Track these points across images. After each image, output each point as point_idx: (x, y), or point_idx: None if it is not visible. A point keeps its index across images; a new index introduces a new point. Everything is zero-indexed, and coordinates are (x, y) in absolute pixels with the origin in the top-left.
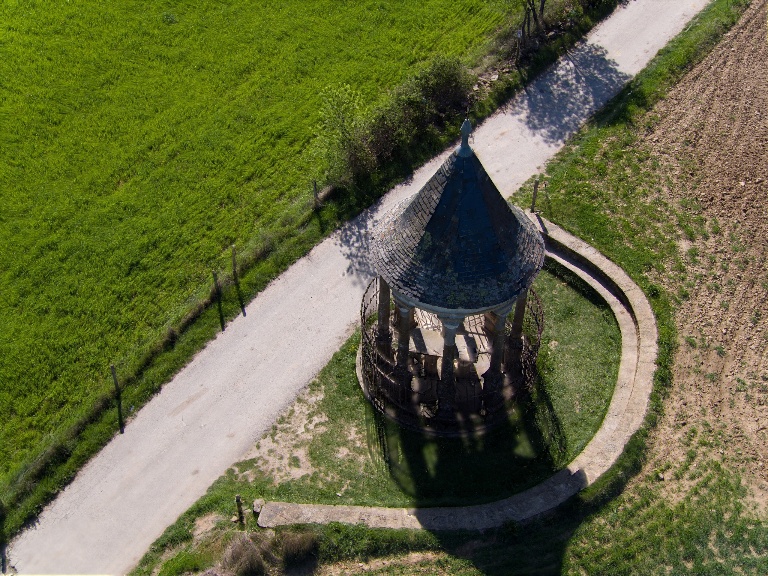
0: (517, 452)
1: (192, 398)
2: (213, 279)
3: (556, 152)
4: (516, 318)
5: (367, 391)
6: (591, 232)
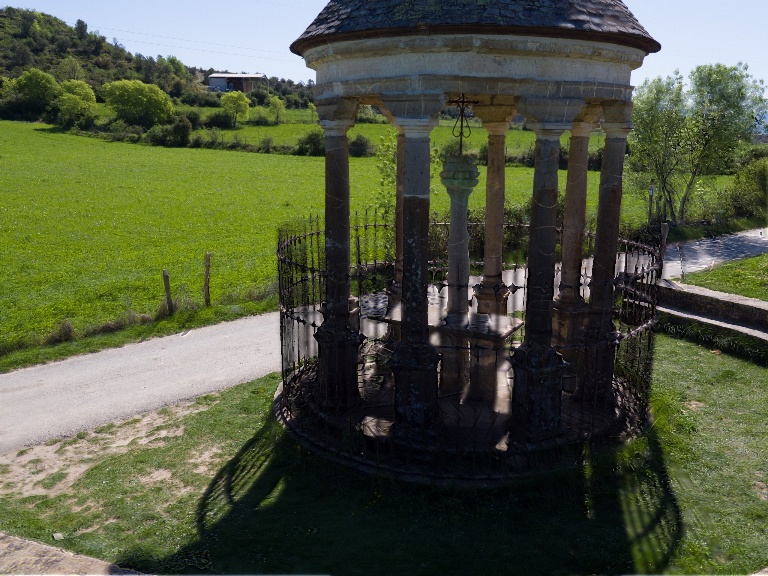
0: (577, 542)
1: (8, 389)
2: (164, 287)
3: (698, 269)
4: (597, 250)
5: (279, 399)
6: (762, 298)
